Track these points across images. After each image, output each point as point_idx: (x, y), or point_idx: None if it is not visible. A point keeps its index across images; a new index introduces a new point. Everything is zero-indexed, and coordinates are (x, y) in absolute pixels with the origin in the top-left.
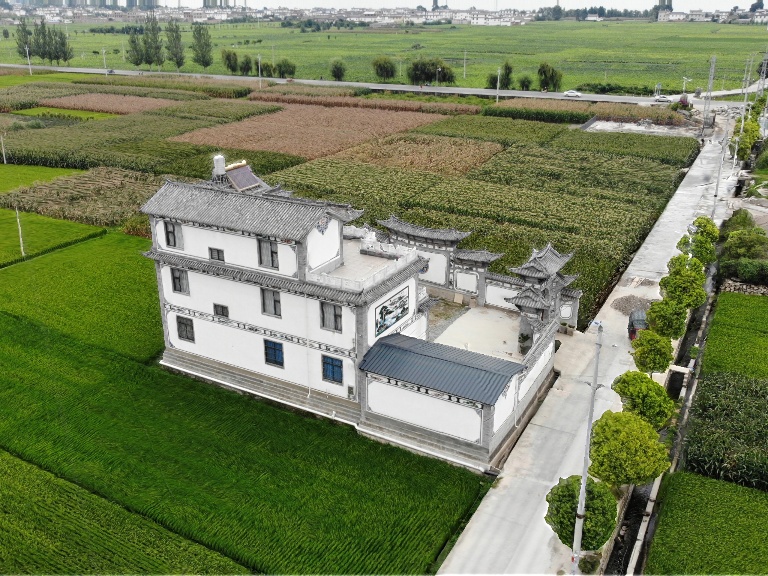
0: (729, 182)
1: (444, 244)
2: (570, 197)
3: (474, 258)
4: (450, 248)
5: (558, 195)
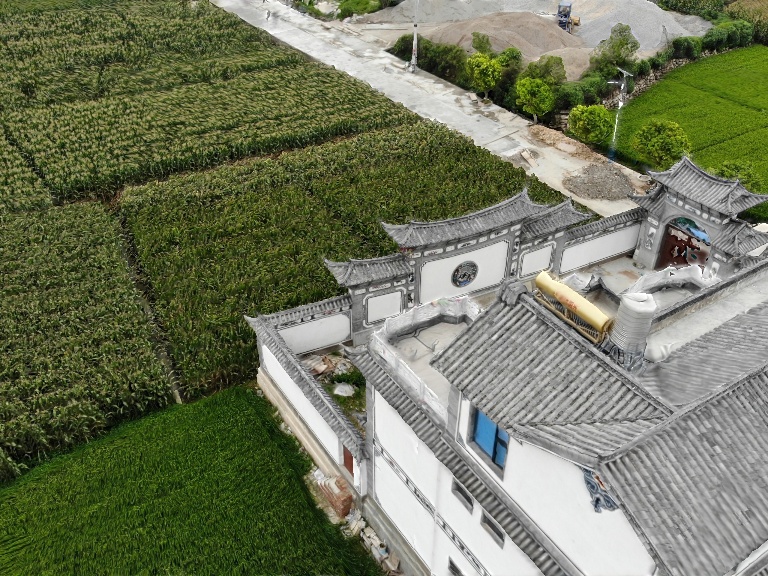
0: (278, 4)
1: (510, 225)
2: (231, 82)
3: (563, 223)
4: (515, 226)
5: (210, 85)
